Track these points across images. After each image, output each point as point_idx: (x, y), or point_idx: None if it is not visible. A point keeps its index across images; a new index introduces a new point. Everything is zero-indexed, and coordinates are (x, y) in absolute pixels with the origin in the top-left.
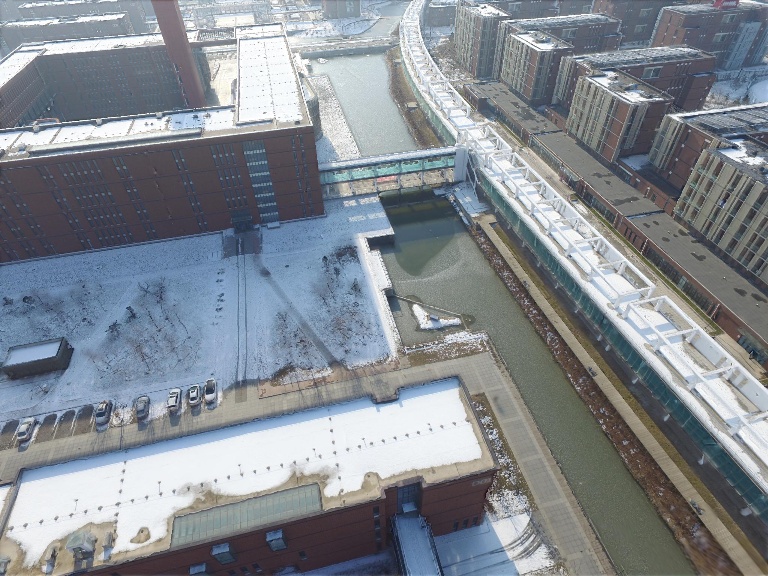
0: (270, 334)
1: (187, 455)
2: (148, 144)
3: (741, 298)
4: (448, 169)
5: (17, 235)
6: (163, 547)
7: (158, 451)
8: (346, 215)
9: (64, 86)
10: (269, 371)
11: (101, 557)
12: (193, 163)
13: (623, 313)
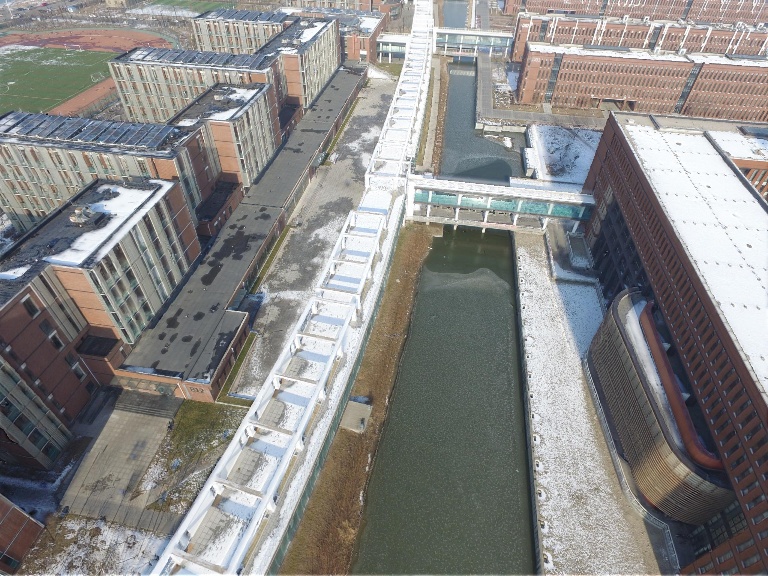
0: None
1: None
2: None
3: None
4: None
5: None
6: None
7: None
8: None
9: None
10: None
11: None
12: None
13: None
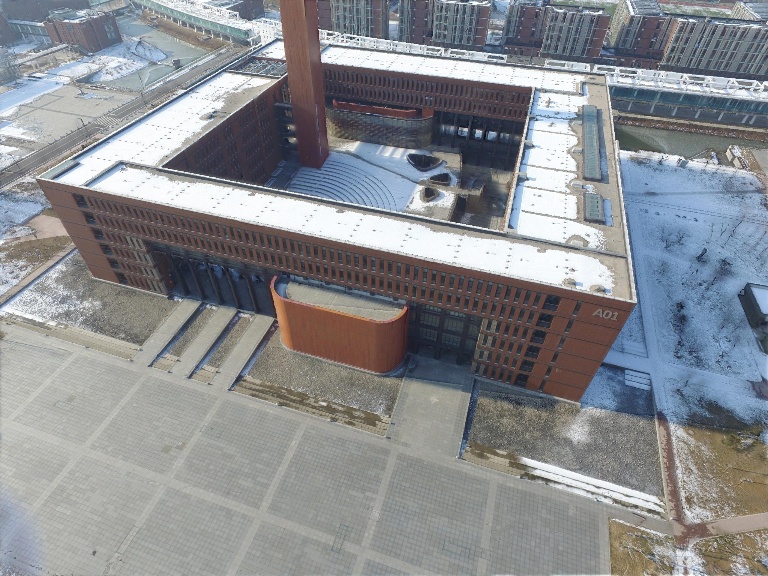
0: (729, 206)
1: None
2: None
3: (733, 82)
4: None
5: None
6: None
7: None
8: None
9: None
10: (767, 214)
11: None
12: None
13: (767, 96)
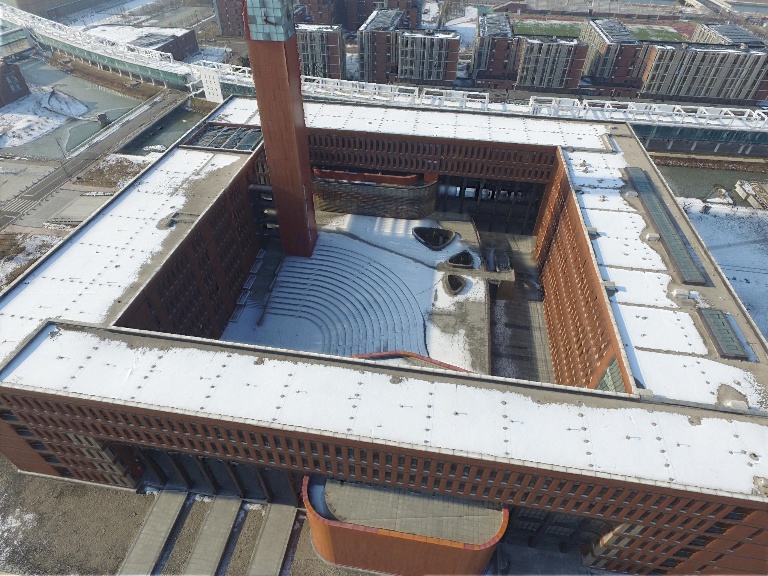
0: None
1: None
2: None
3: None
4: None
5: None
6: None
7: None
8: None
9: None
10: None
11: None
12: None
13: (764, 125)
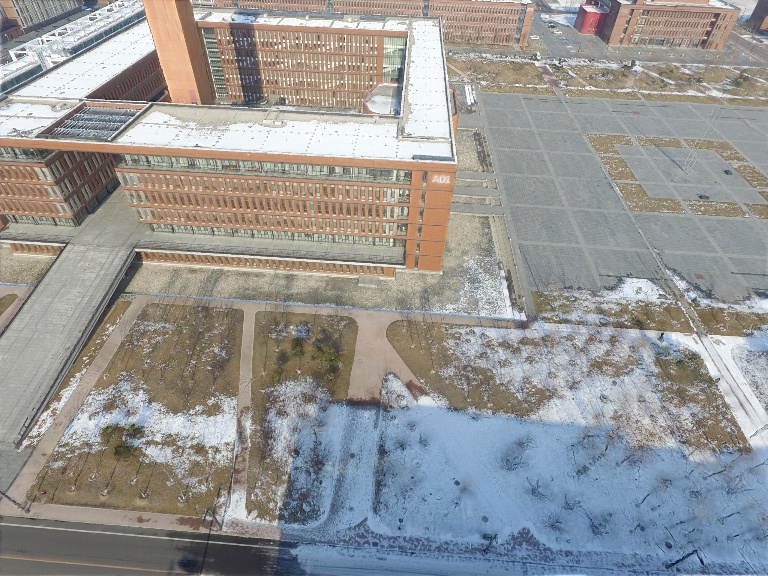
0: None
1: None
2: None
3: None
4: None
5: None
6: None
7: None
8: None
9: None
10: None
11: None
12: None
13: None
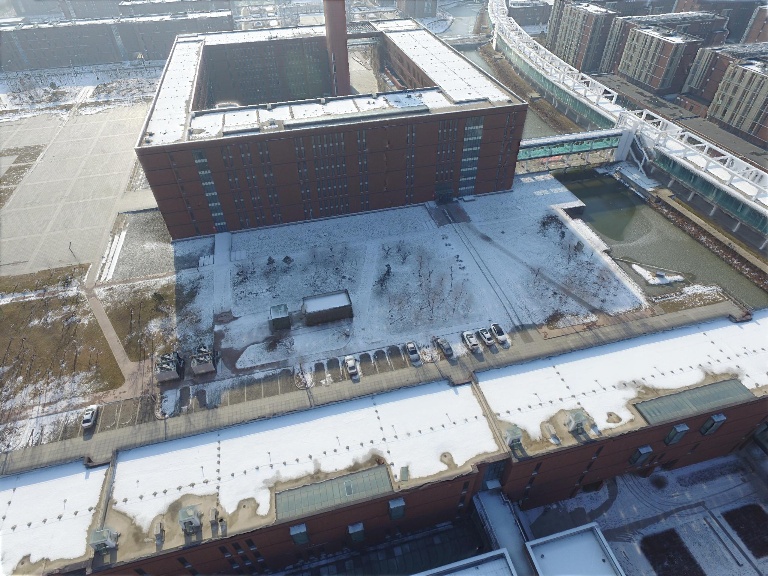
0: (523, 288)
1: (603, 361)
2: (391, 119)
3: None
4: (609, 150)
5: (255, 204)
6: (640, 425)
7: (576, 358)
8: (530, 190)
9: (220, 75)
10: (540, 317)
11: (593, 433)
12: (421, 137)
13: None
